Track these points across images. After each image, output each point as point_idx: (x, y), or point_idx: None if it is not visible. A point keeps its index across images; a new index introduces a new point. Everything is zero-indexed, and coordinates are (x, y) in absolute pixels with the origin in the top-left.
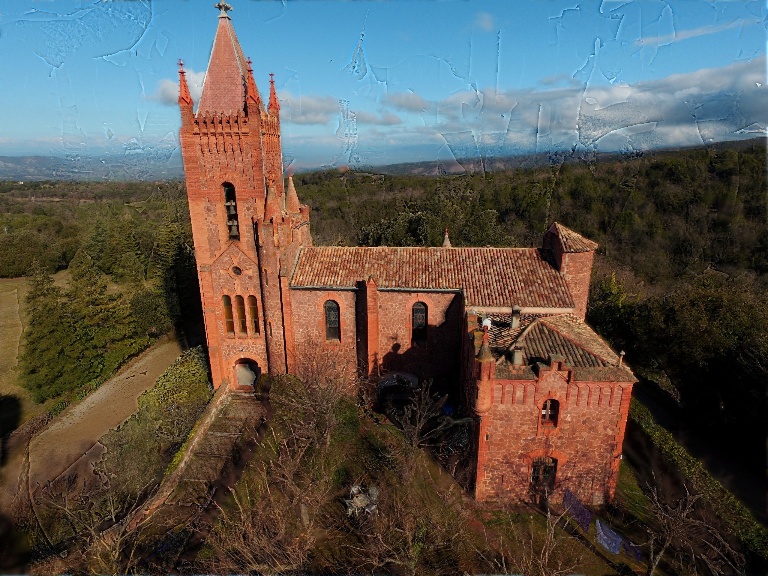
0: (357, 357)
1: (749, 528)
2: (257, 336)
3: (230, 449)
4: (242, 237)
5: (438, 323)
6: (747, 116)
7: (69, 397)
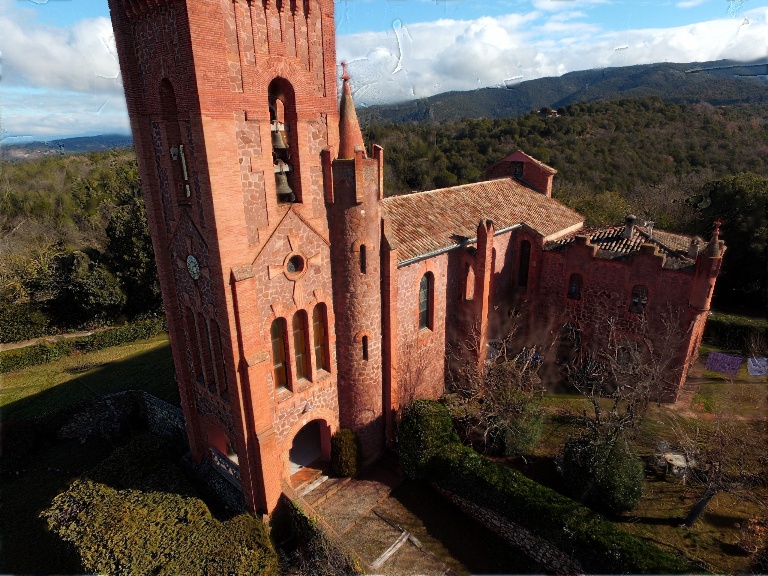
0: (445, 342)
1: (761, 323)
2: (324, 374)
3: (431, 561)
4: (305, 194)
5: (500, 269)
6: (414, 85)
7: None
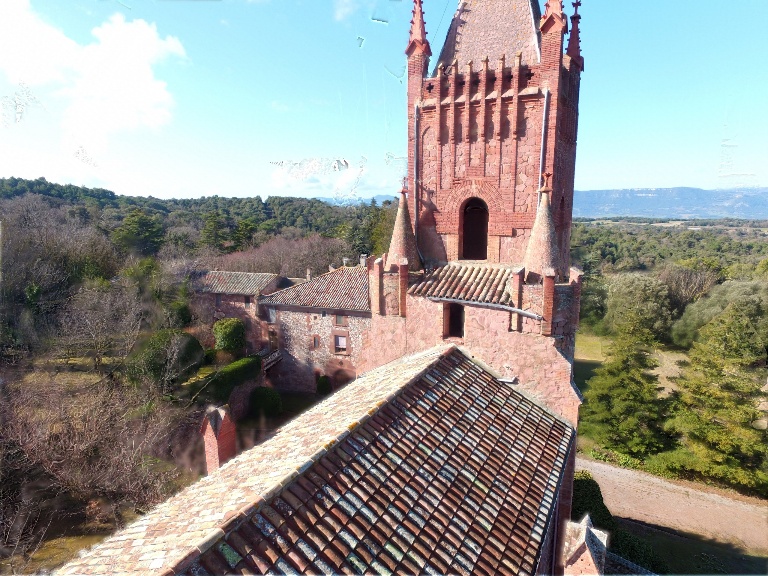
0: None
1: None
2: None
3: None
4: None
5: None
6: None
7: (584, 445)
